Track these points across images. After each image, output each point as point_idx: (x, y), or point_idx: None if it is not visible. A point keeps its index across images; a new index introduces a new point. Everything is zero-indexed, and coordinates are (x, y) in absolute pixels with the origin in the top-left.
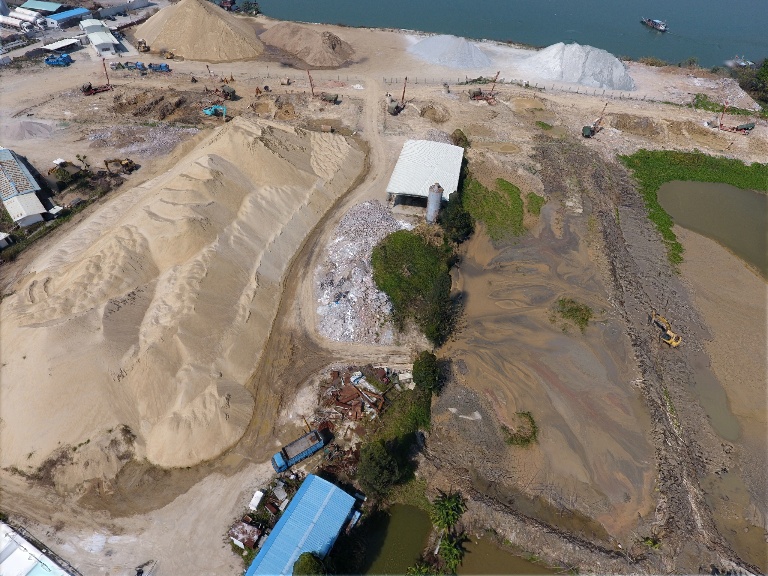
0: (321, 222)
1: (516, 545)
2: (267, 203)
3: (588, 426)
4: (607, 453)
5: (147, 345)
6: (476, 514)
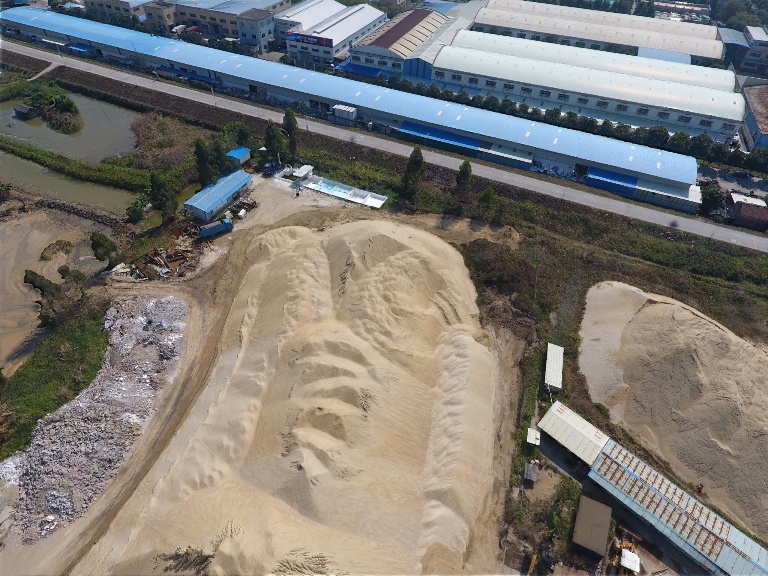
0: (149, 467)
1: (105, 211)
2: (220, 443)
3: (1, 255)
4: (4, 242)
5: (315, 246)
6: (119, 217)
